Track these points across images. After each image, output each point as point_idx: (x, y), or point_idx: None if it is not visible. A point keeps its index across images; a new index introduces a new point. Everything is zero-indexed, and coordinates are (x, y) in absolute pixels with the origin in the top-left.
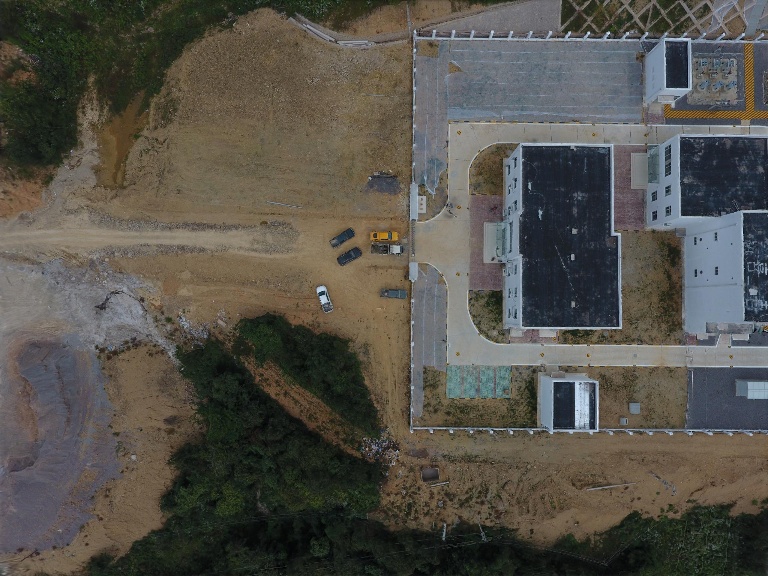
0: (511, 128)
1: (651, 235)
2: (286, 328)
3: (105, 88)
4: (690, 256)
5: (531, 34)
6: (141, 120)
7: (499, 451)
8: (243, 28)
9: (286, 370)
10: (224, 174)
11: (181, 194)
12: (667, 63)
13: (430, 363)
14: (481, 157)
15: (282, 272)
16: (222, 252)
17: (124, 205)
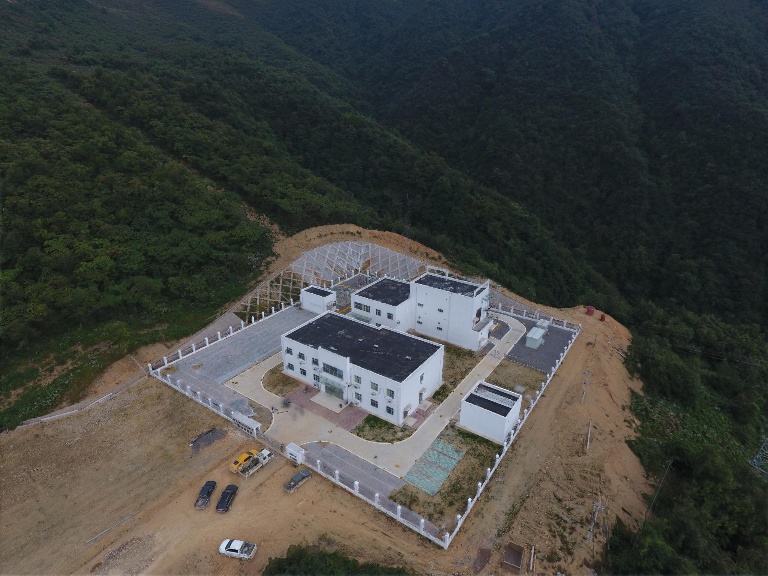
0: (268, 361)
1: None
2: None
3: None
4: (428, 330)
5: (231, 329)
6: None
7: (516, 485)
8: None
9: None
10: None
11: None
12: None
13: (388, 490)
14: (266, 381)
15: None
16: None
17: None
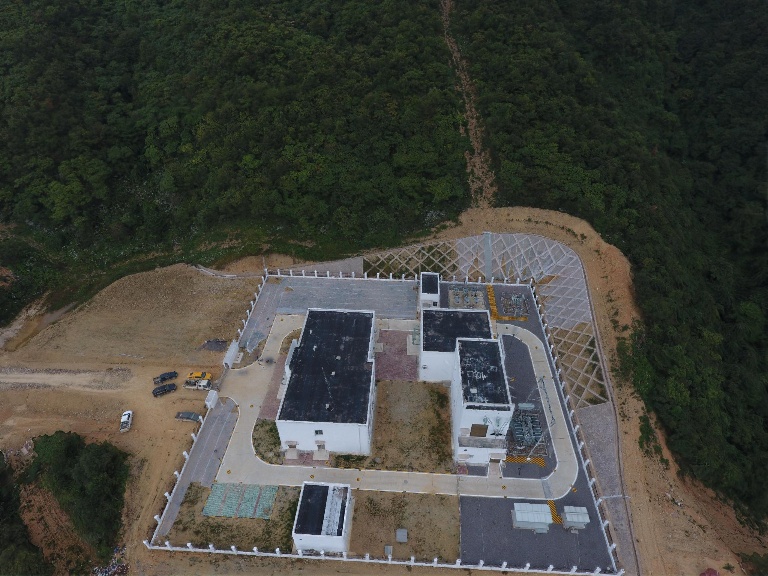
0: None
1: (423, 385)
2: (77, 444)
3: (53, 298)
4: (452, 397)
5: (341, 274)
6: (64, 316)
7: None
8: (161, 270)
9: (55, 487)
10: (99, 338)
11: (58, 349)
12: (425, 284)
13: (198, 479)
14: (294, 333)
15: (103, 404)
16: (62, 388)
17: (10, 358)
